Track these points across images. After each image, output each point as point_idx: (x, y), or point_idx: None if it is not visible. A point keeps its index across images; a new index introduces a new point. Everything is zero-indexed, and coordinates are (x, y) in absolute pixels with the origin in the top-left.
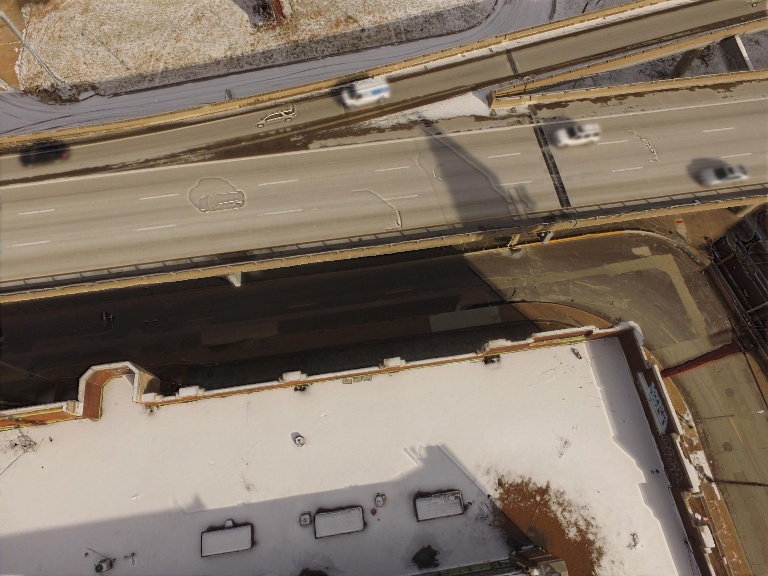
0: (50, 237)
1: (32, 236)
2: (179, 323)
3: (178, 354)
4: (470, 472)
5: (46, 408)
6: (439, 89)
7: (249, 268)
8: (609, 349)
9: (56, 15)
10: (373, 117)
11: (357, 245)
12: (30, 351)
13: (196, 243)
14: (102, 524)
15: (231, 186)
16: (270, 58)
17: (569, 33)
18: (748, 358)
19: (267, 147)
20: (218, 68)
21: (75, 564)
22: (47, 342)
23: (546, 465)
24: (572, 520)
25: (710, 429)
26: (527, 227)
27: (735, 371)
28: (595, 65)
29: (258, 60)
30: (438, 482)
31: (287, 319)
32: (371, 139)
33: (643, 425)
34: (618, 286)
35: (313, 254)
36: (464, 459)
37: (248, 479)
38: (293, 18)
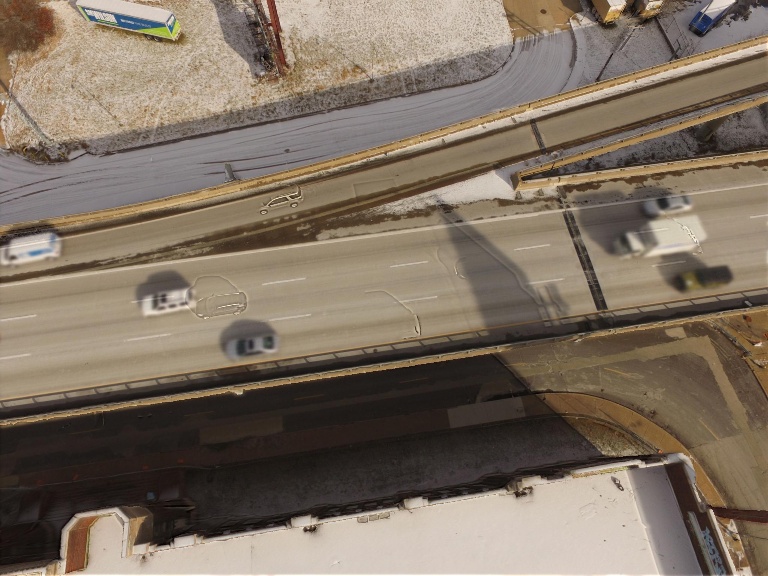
0: (31, 349)
1: (11, 348)
2: (176, 418)
3: (175, 455)
4: None
5: (23, 573)
6: (458, 167)
7: (252, 387)
8: (654, 478)
9: (44, 64)
10: (387, 201)
11: (372, 358)
12: (14, 451)
13: (193, 356)
14: None
15: (232, 286)
16: (273, 112)
17: (598, 99)
18: None
19: (271, 238)
20: (217, 123)
21: None
22: (33, 441)
23: None
24: None
25: (756, 541)
26: (561, 338)
27: None
28: (629, 139)
29: (260, 114)
30: None
31: (293, 413)
32: (385, 228)
33: (695, 573)
34: (651, 373)
35: (323, 373)
36: None
37: None
38: (297, 68)
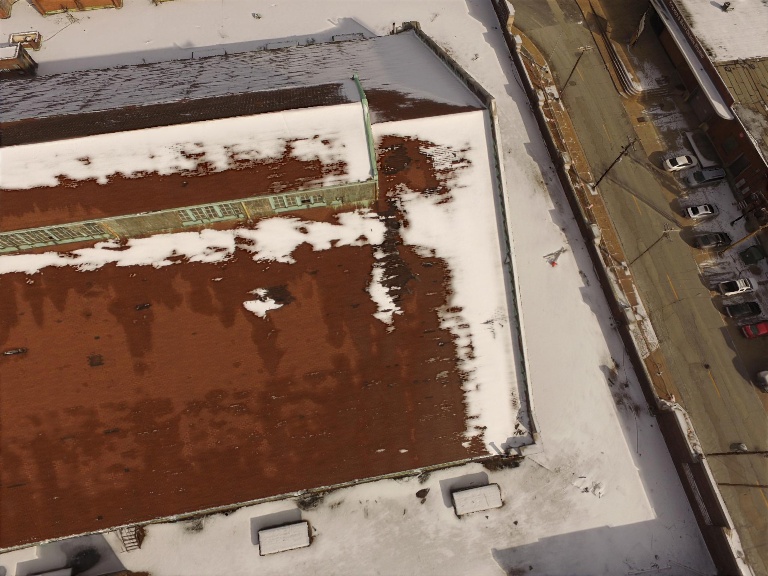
0: None
1: None
2: None
3: None
4: (371, 29)
5: None
6: None
7: None
8: None
9: None
10: None
11: None
12: None
13: None
14: (127, 54)
15: None
16: None
17: None
18: (593, 34)
19: None
20: None
21: None
22: None
23: (422, 25)
24: None
25: (561, 74)
26: None
27: (583, 42)
28: None
29: None
30: (350, 33)
31: None
32: None
33: (489, 7)
34: None
35: None
36: (368, 23)
37: (223, 33)
38: None
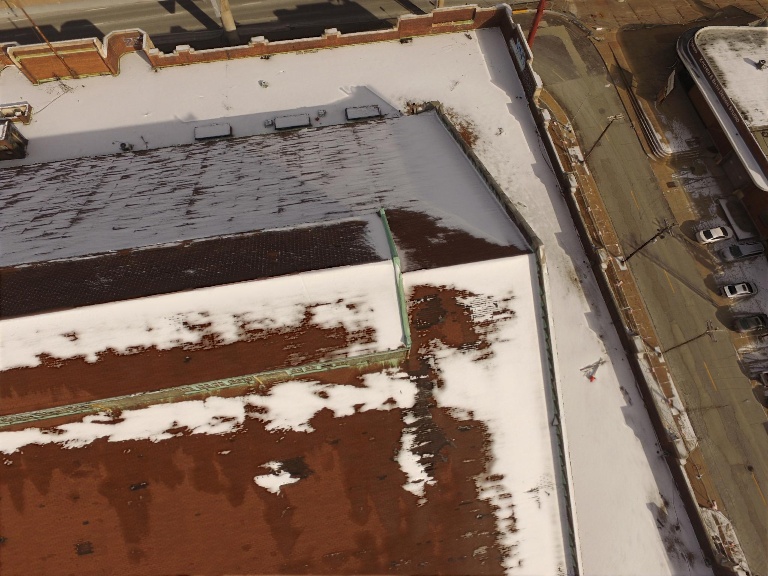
0: None
1: None
2: None
3: None
4: (387, 99)
5: (81, 43)
6: None
7: None
8: (492, 34)
9: None
10: None
11: None
12: None
13: None
14: (124, 129)
15: None
16: None
17: None
18: (618, 89)
19: None
20: None
21: (106, 148)
22: None
23: (441, 95)
24: (458, 122)
25: (585, 133)
26: None
27: (607, 98)
28: None
29: None
30: (364, 104)
31: None
32: None
33: (513, 74)
34: None
35: None
36: (383, 92)
37: (227, 104)
38: None
